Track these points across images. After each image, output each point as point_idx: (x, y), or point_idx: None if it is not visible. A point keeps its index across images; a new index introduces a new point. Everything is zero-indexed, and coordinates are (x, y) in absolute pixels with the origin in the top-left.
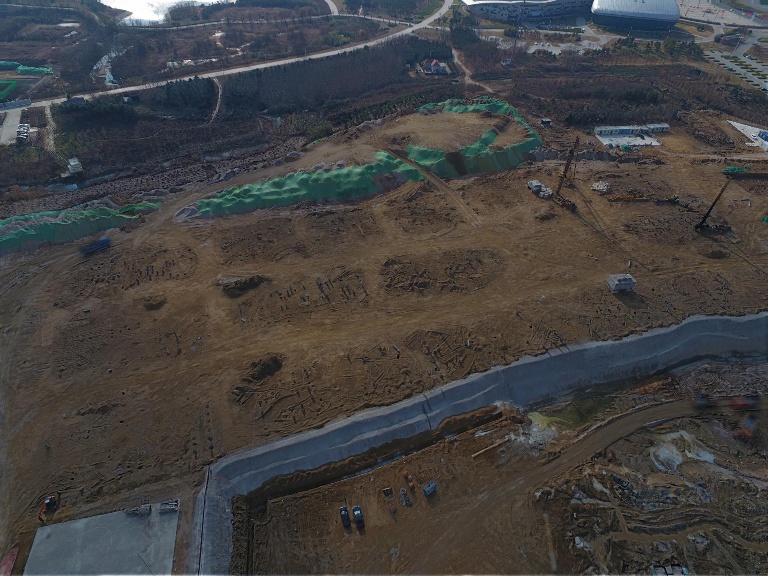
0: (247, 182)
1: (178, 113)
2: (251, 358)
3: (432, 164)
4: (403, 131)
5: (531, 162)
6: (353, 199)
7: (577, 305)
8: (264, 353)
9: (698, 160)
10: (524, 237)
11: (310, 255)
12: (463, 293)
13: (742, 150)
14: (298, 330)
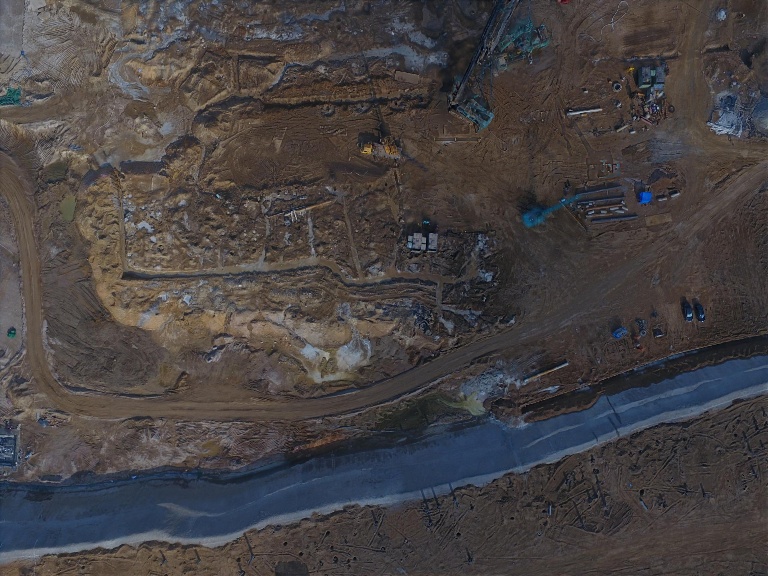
0: None
1: None
2: None
3: None
4: None
5: None
6: None
7: (379, 573)
8: None
9: None
10: None
11: None
12: None
13: None
14: (767, 542)
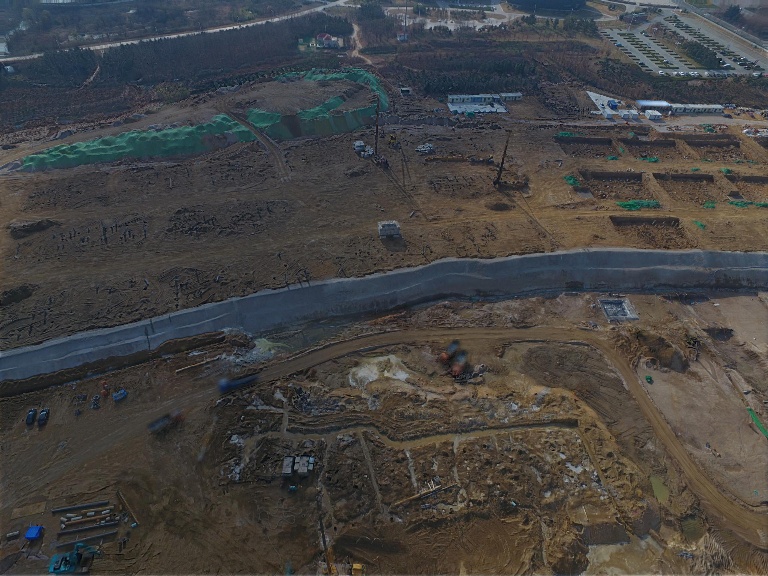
0: (79, 140)
1: (53, 81)
2: (6, 288)
3: (266, 126)
4: (252, 96)
5: (370, 126)
6: (178, 157)
7: (340, 248)
8: (20, 284)
9: (535, 126)
10: (325, 191)
11: (110, 204)
12: (238, 237)
13: (583, 117)
14: (63, 266)
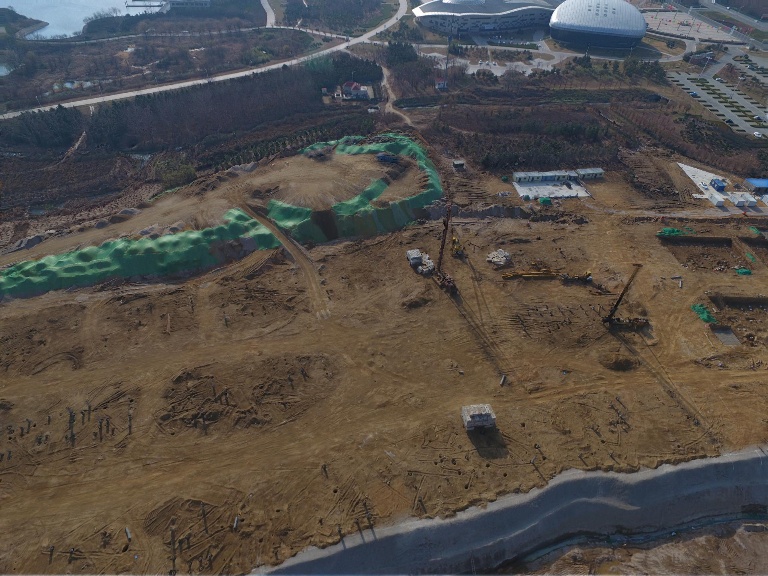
0: (50, 252)
1: (30, 150)
2: None
3: (293, 226)
4: (273, 180)
5: (423, 221)
6: (179, 275)
7: (412, 451)
8: None
9: (630, 218)
10: (377, 335)
11: (83, 364)
12: (262, 430)
13: (686, 204)
14: (4, 498)
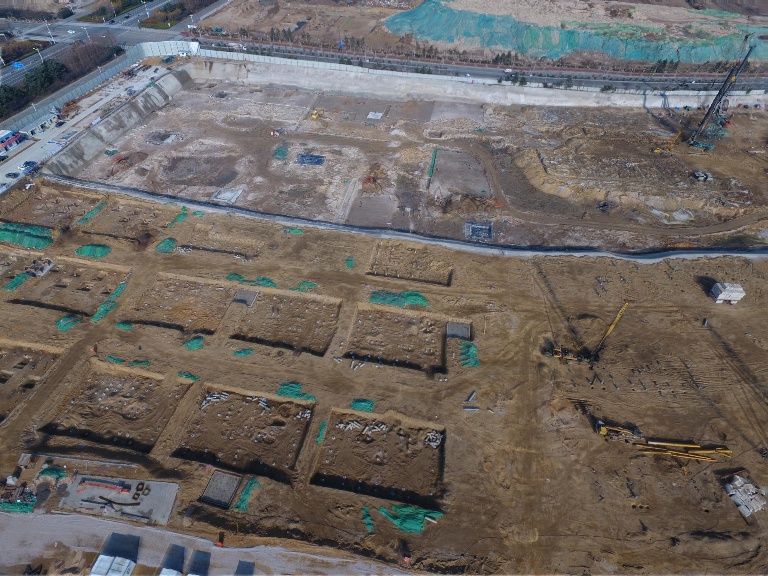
0: None
1: None
2: None
3: None
4: None
5: None
6: None
7: (767, 288)
8: None
9: (475, 575)
10: None
11: None
12: None
13: None
14: None
